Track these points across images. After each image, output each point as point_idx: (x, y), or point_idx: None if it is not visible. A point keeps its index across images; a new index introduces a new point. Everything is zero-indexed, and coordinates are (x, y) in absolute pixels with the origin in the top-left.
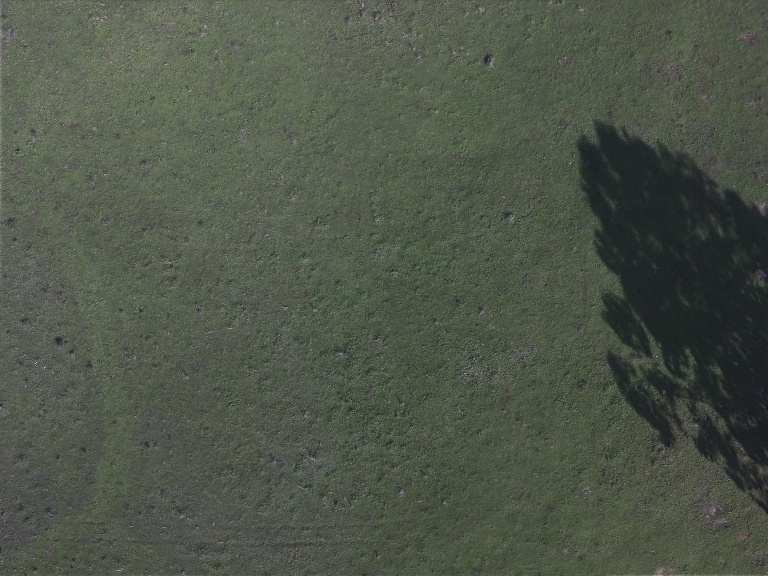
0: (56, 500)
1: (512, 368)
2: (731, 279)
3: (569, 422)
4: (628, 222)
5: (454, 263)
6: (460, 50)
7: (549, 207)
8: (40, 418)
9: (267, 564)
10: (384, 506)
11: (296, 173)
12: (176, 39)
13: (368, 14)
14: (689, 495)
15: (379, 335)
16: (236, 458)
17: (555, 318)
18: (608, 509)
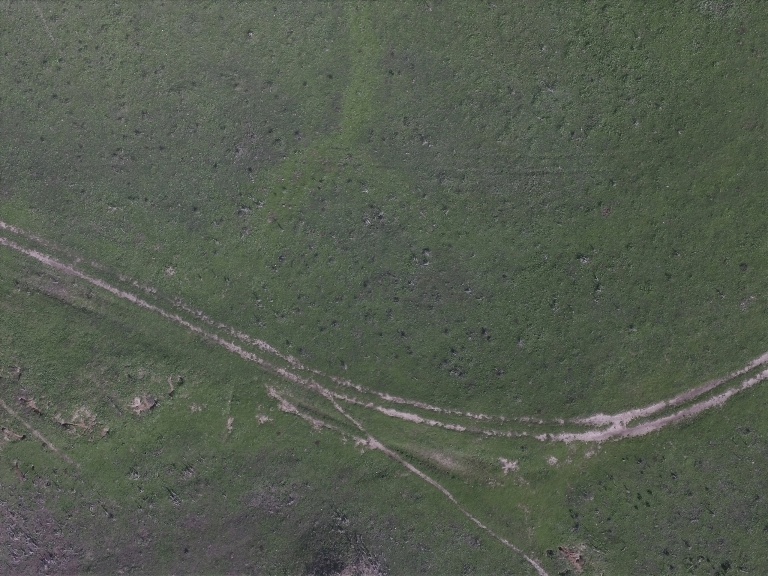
0: (303, 125)
1: (747, 2)
2: None
3: None
4: None
5: None
6: None
7: None
8: (288, 45)
9: (506, 191)
10: (620, 136)
11: None
12: None
13: None
14: None
15: None
16: (476, 89)
17: None
18: None
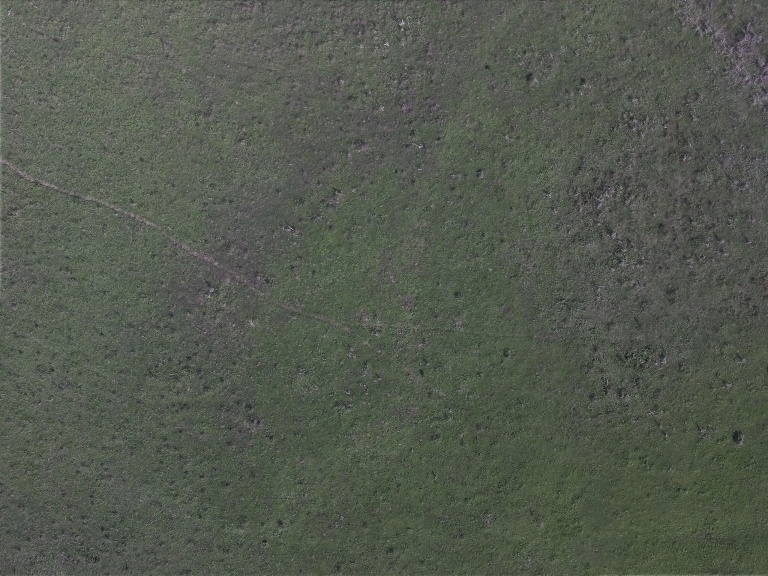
0: None
1: None
2: None
3: None
4: None
5: None
6: (708, 427)
7: None
8: None
9: None
10: None
11: (543, 555)
12: (421, 424)
13: (613, 391)
14: None
15: None
16: None
17: None
18: None
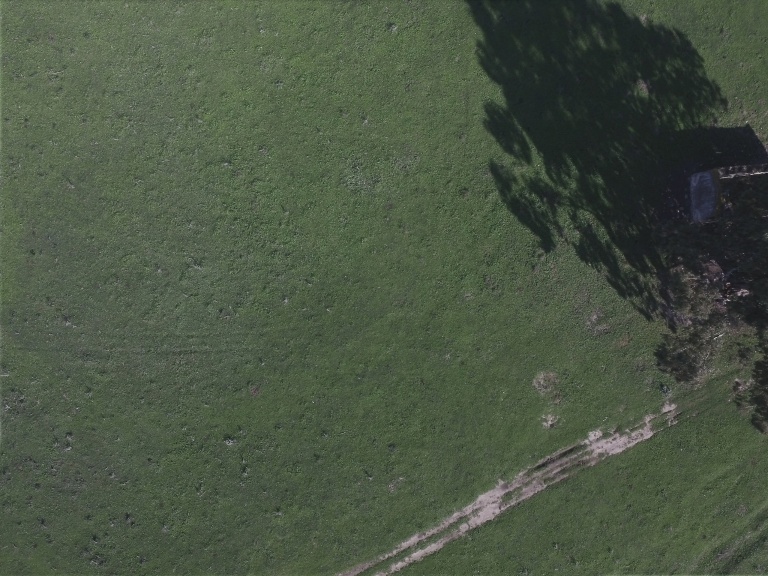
0: None
1: (395, 176)
2: (612, 88)
3: (451, 229)
4: (510, 32)
5: (338, 74)
6: None
7: (432, 18)
8: None
9: (152, 371)
10: (269, 314)
11: None
12: None
13: None
14: (570, 302)
15: (264, 145)
16: (122, 267)
17: (438, 127)
18: (489, 314)
